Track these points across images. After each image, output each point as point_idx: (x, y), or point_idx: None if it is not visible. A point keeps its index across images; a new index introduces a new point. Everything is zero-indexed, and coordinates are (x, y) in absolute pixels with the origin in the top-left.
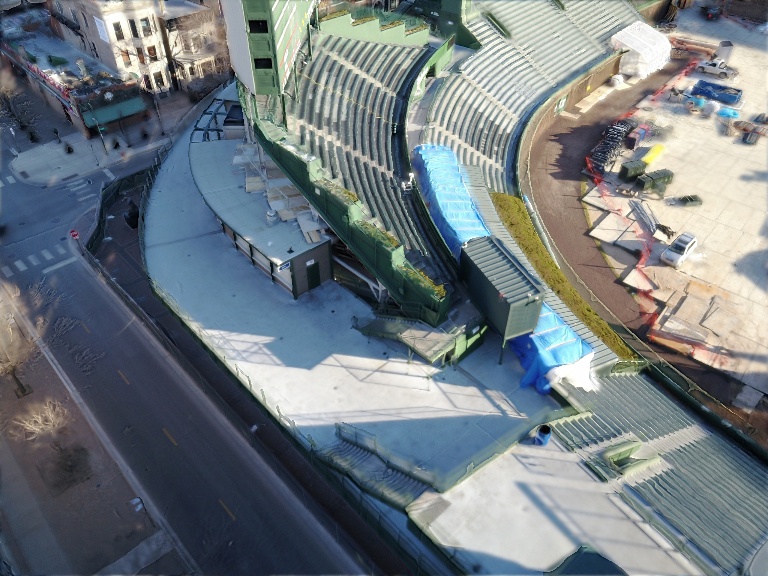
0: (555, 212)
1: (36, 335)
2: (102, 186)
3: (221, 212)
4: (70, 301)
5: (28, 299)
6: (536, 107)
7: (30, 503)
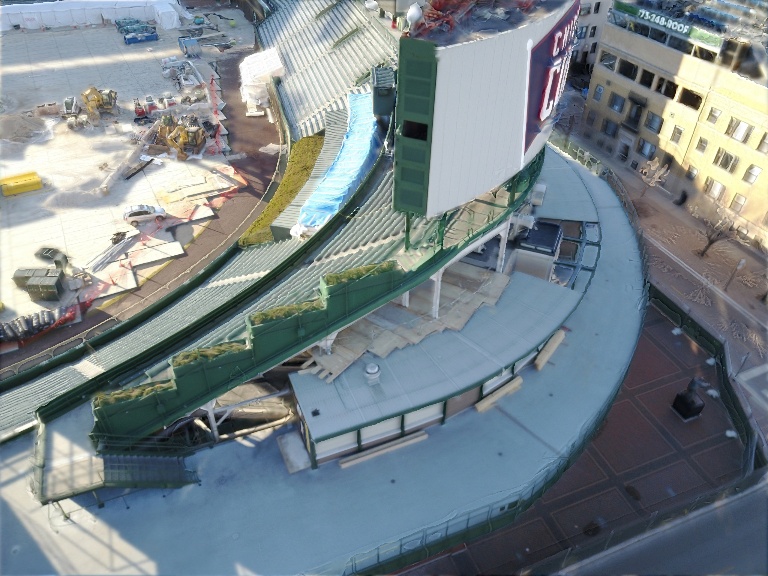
0: (181, 283)
1: (723, 296)
2: (767, 450)
3: (552, 152)
4: (711, 321)
5: (761, 335)
6: (3, 393)
7: (652, 198)
